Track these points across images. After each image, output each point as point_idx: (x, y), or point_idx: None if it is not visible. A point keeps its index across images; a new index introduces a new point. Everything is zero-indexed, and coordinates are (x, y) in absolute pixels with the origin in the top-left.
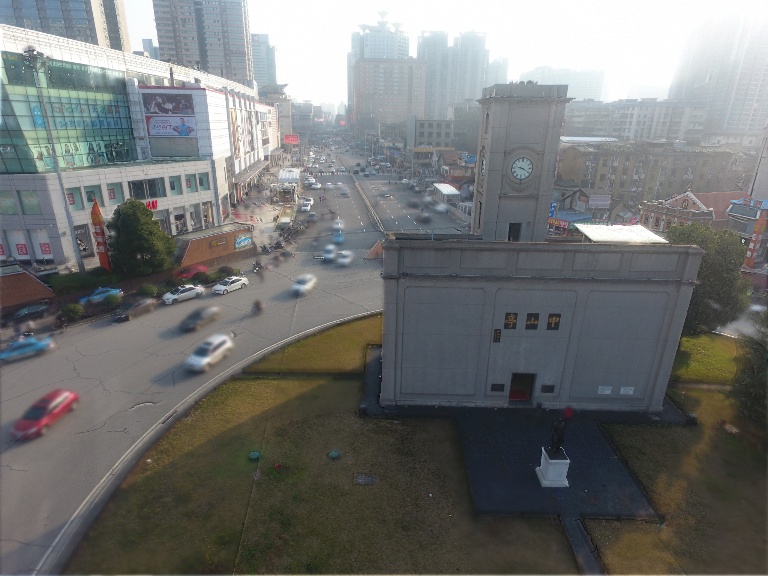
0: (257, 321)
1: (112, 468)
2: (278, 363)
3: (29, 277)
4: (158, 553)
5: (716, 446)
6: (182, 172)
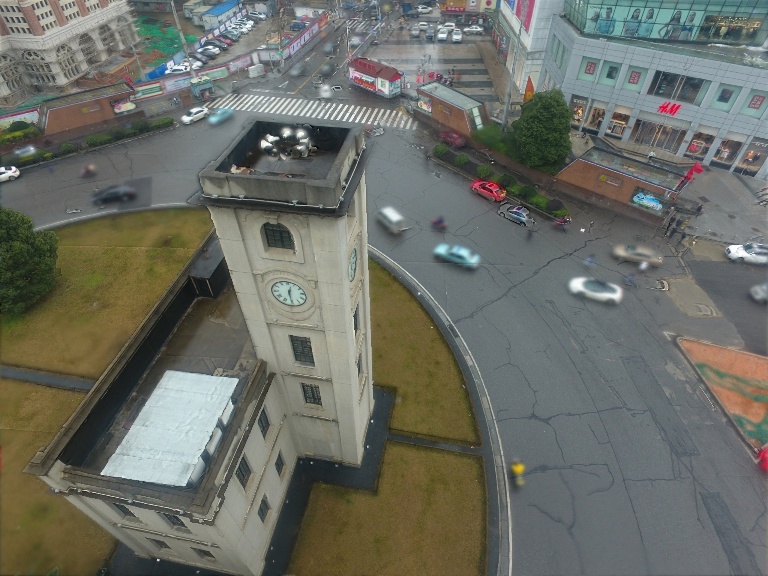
0: (432, 240)
1: None
2: None
3: (464, 115)
4: (190, 227)
5: (66, 570)
6: (750, 83)
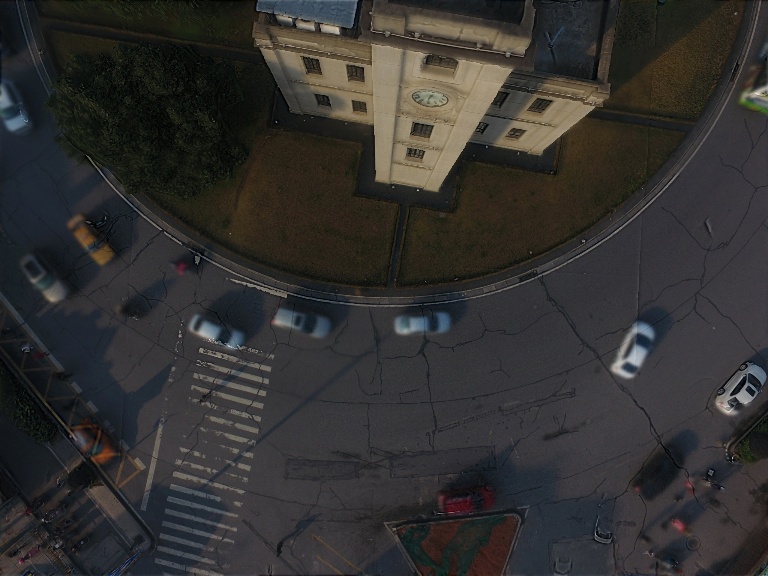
0: (685, 263)
1: (759, 14)
2: (653, 144)
3: None
4: None
5: None
6: None
